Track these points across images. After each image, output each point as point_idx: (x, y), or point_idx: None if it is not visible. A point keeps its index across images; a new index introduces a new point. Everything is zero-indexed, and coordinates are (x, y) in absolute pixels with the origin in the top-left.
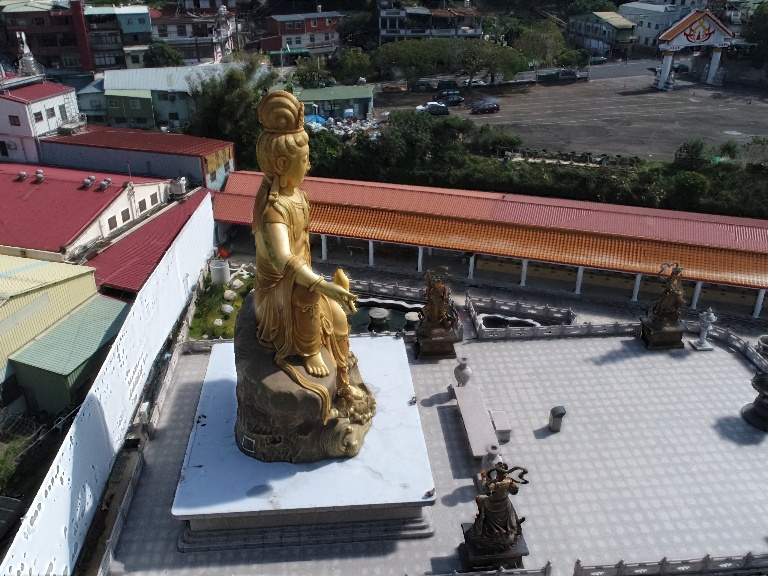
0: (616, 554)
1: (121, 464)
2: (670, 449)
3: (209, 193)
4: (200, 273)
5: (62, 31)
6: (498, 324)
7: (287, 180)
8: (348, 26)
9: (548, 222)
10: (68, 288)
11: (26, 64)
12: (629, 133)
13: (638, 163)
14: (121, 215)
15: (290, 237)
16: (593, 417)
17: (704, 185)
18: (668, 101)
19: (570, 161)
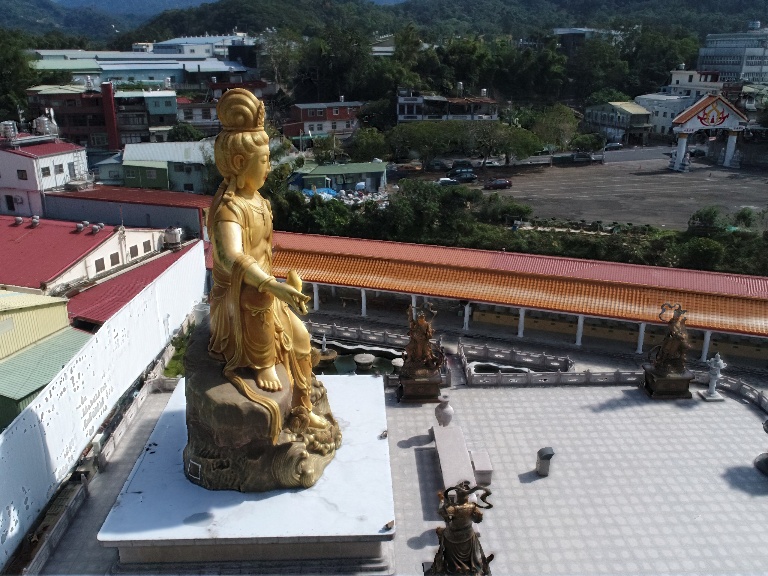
0: None
1: (63, 496)
2: (672, 497)
3: (202, 240)
4: (185, 318)
5: (92, 112)
6: (491, 372)
7: (245, 181)
8: (367, 113)
9: None
10: (36, 316)
11: (40, 124)
12: (642, 206)
13: (650, 231)
14: (110, 258)
15: (245, 240)
16: (586, 463)
17: (719, 251)
18: (684, 180)
19: (580, 229)
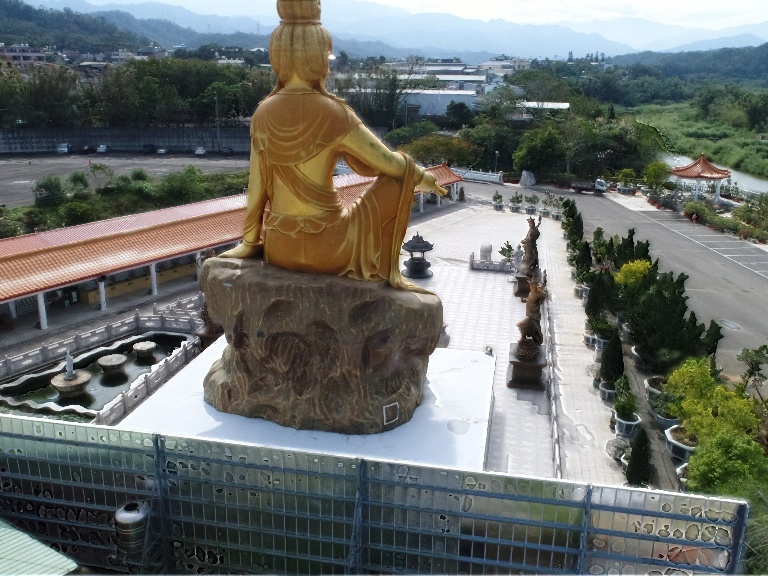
0: None
1: None
2: None
3: None
4: None
5: None
6: None
7: None
8: None
9: None
10: None
11: None
12: None
13: None
14: None
15: None
16: None
17: None
18: None
19: None
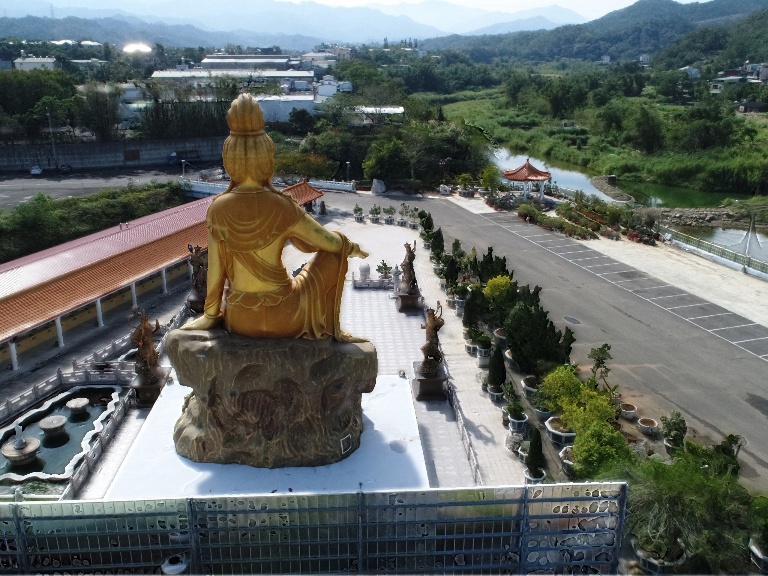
0: (421, 354)
1: None
2: None
3: None
4: None
5: None
6: None
7: None
8: None
9: (6, 290)
10: None
11: None
12: None
13: None
14: None
15: None
16: None
17: None
18: None
19: None
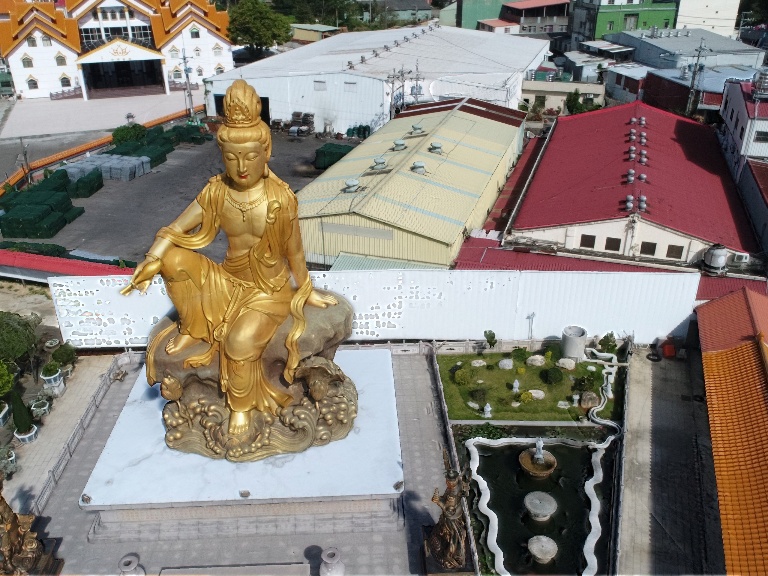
0: None
1: None
2: None
3: (696, 273)
4: (590, 337)
5: None
6: None
7: None
8: None
9: None
10: (417, 241)
11: None
12: None
13: None
14: (606, 240)
15: (210, 222)
16: None
17: None
18: None
19: None
